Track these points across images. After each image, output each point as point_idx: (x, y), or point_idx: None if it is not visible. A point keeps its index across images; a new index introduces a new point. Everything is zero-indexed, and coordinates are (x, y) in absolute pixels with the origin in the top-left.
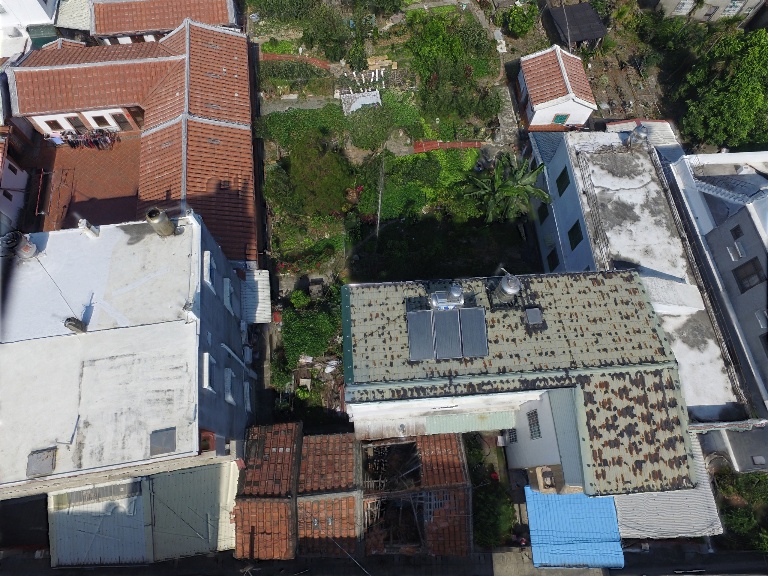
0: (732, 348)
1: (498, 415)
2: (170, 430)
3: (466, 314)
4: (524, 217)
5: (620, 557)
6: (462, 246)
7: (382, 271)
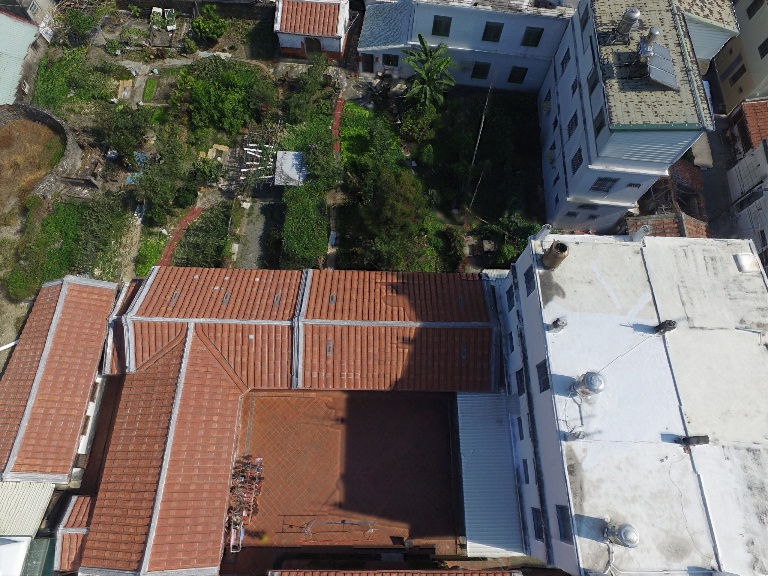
0: None
1: None
2: (738, 257)
3: None
4: None
5: None
6: (448, 134)
7: None
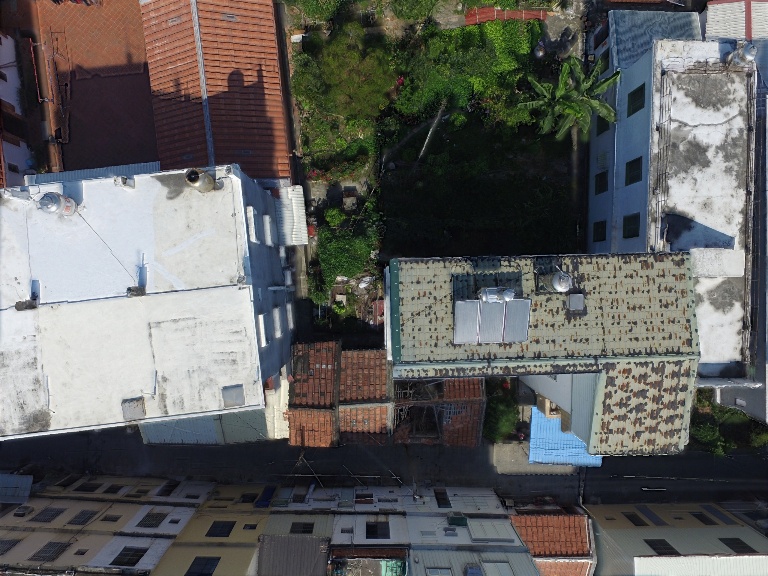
0: (756, 316)
1: None
2: (238, 387)
3: (512, 305)
4: None
5: (599, 459)
6: None
7: (418, 181)
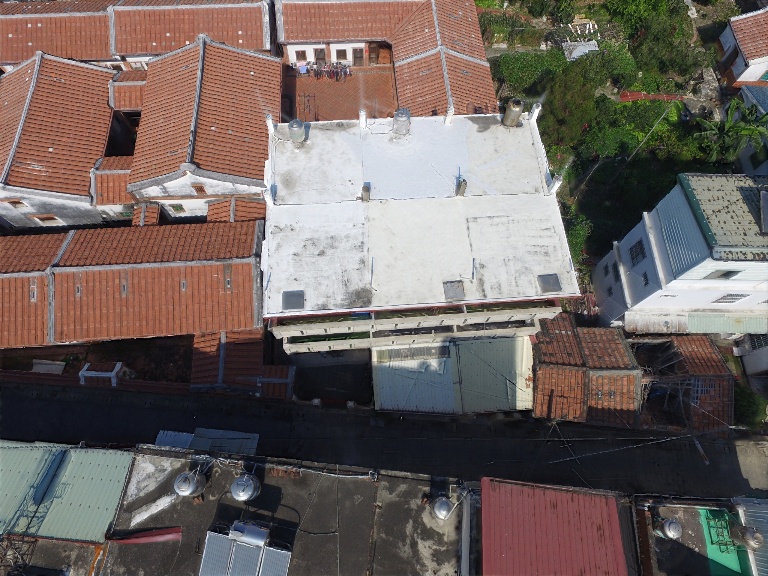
0: None
1: (753, 320)
2: (554, 275)
3: None
4: (732, 163)
5: None
6: None
7: (606, 201)
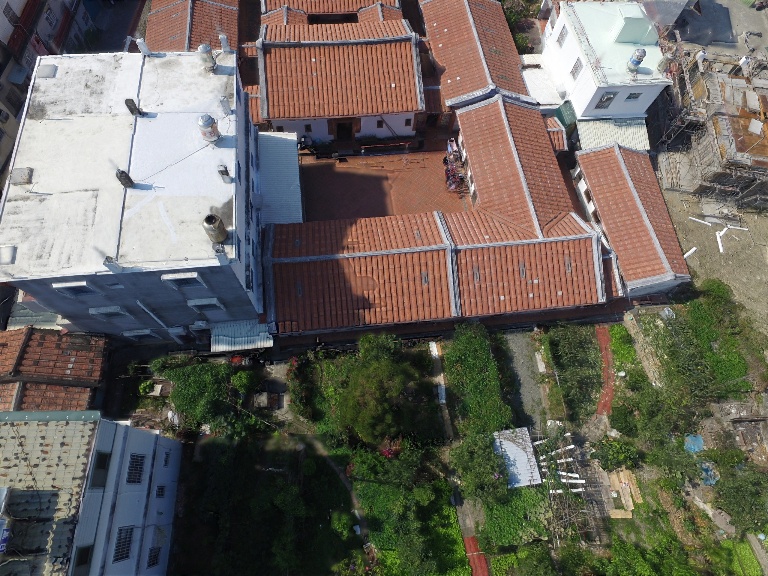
0: None
1: None
2: (11, 260)
3: None
4: None
5: None
6: None
7: None
